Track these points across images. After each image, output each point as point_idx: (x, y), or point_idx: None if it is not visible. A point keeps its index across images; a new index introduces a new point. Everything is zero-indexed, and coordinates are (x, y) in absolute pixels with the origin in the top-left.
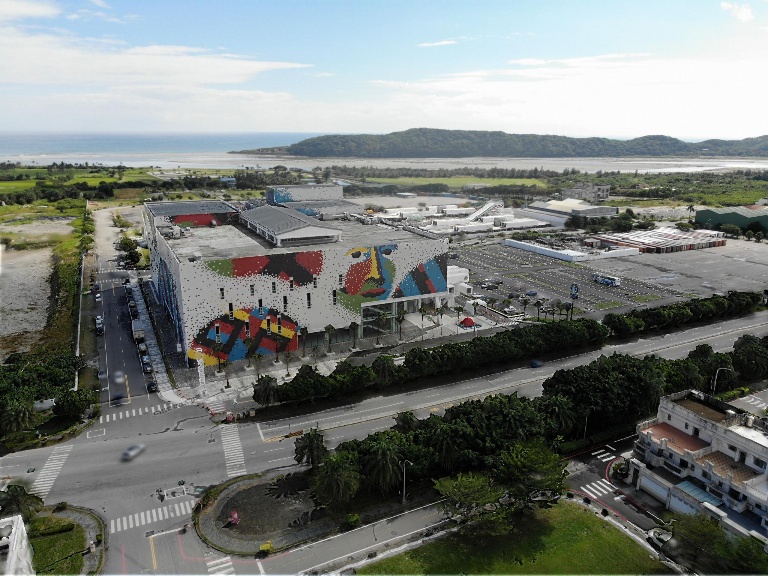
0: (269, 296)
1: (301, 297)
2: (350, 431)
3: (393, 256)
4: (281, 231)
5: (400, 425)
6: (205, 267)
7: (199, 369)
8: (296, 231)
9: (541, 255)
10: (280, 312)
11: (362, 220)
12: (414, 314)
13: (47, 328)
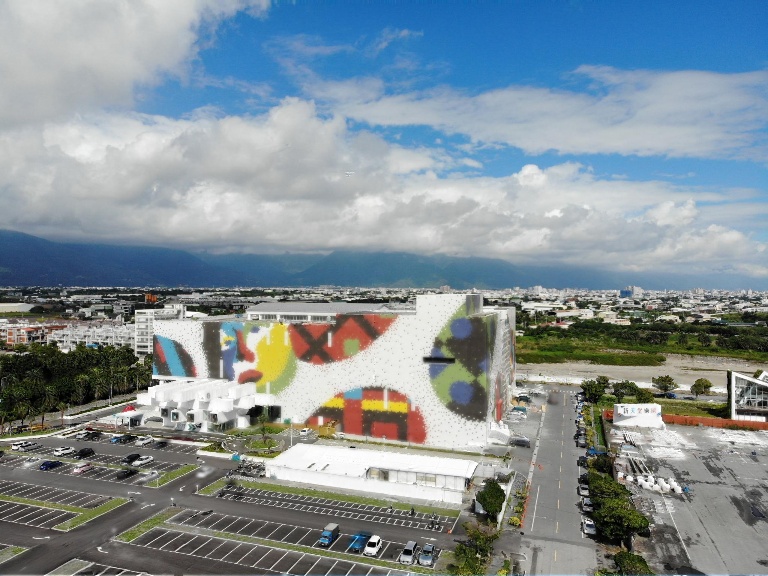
0: None
1: None
2: None
3: None
4: None
5: None
6: None
7: None
8: None
9: None
10: None
11: None
12: None
13: None
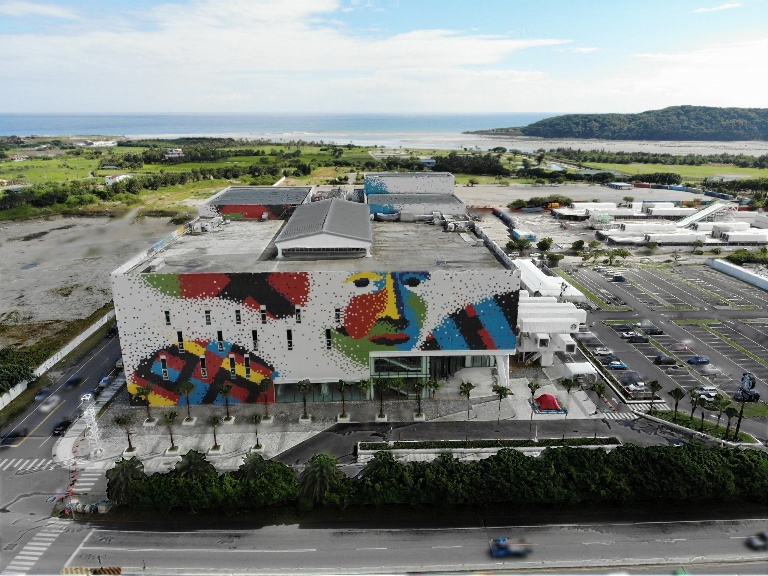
0: (232, 328)
1: (278, 334)
2: None
3: (422, 289)
4: (283, 238)
5: None
6: (143, 282)
7: (88, 422)
8: (303, 239)
9: (761, 291)
10: (248, 350)
11: (447, 225)
12: (480, 369)
13: (79, 319)
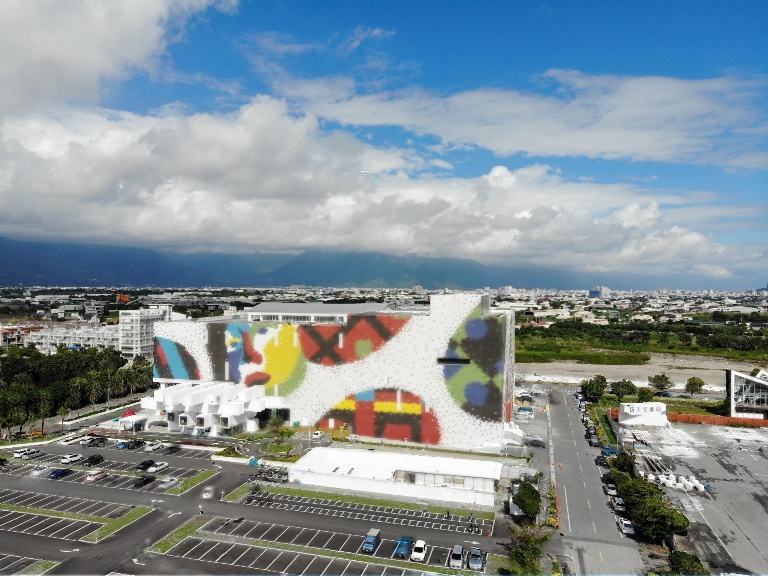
0: None
1: None
2: None
3: None
4: None
5: None
6: None
7: None
8: None
9: None
10: None
11: None
12: None
13: None
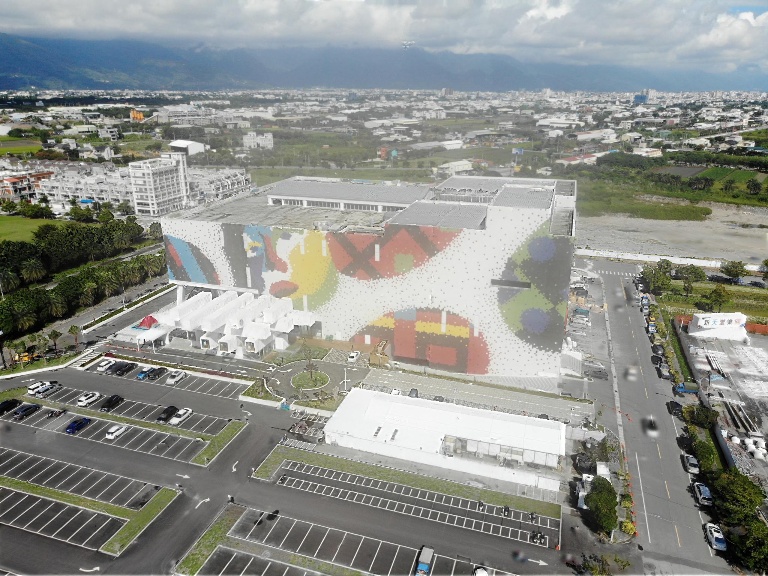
0: None
1: None
2: None
3: None
4: None
5: None
6: None
7: None
8: None
9: None
10: None
11: None
12: None
13: None
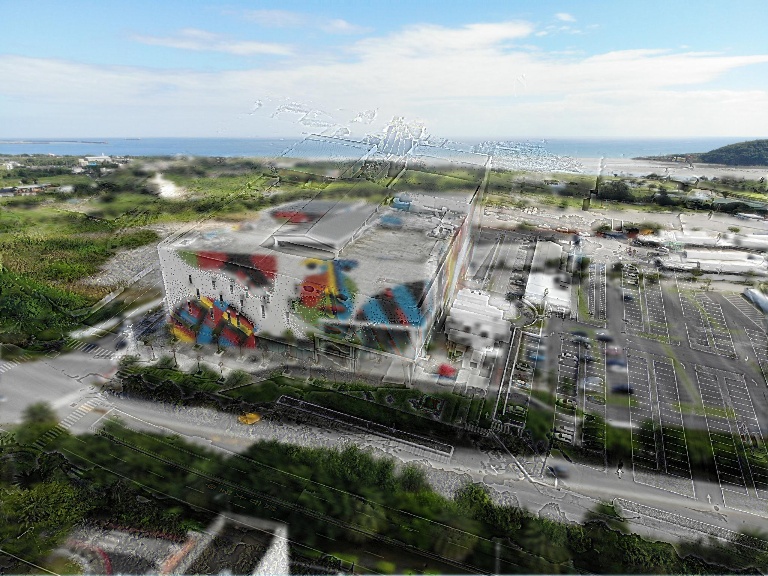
0: (228, 295)
1: (256, 306)
2: (135, 460)
3: (350, 303)
4: (279, 233)
5: (105, 491)
6: (176, 254)
7: None
8: (292, 237)
9: (767, 336)
10: (239, 311)
11: None
12: None
13: None
